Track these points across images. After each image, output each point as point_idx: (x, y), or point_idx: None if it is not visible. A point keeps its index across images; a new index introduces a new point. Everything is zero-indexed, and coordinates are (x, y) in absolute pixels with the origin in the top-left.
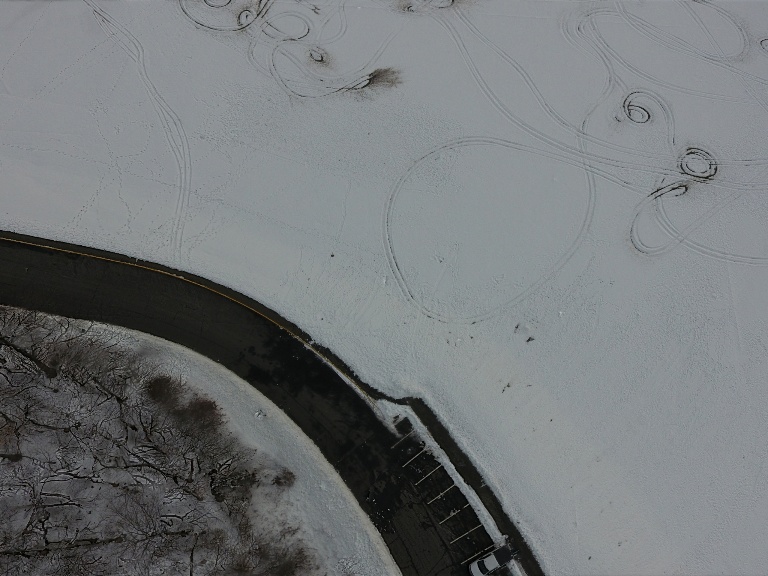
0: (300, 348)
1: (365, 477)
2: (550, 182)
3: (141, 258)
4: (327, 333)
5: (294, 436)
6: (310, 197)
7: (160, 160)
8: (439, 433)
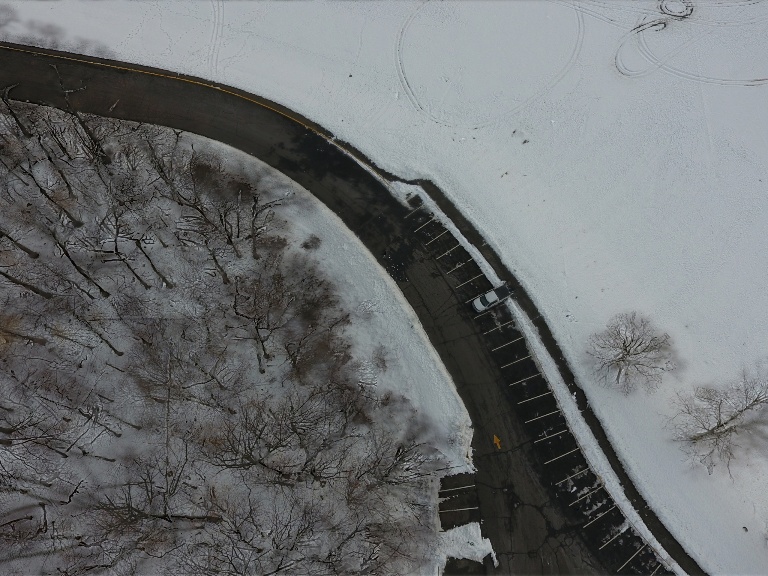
0: (324, 143)
1: (382, 240)
2: (544, 19)
3: (182, 73)
4: (347, 131)
5: (320, 209)
6: (330, 30)
7: (196, 0)
8: (446, 206)
